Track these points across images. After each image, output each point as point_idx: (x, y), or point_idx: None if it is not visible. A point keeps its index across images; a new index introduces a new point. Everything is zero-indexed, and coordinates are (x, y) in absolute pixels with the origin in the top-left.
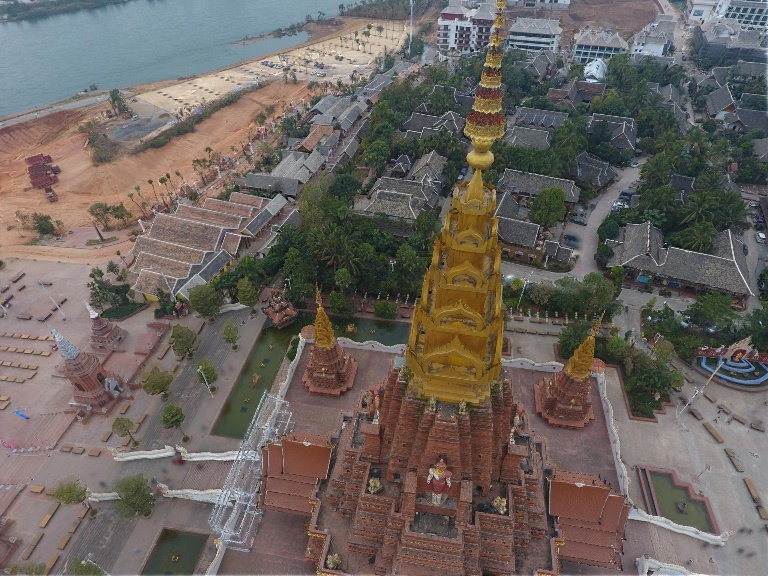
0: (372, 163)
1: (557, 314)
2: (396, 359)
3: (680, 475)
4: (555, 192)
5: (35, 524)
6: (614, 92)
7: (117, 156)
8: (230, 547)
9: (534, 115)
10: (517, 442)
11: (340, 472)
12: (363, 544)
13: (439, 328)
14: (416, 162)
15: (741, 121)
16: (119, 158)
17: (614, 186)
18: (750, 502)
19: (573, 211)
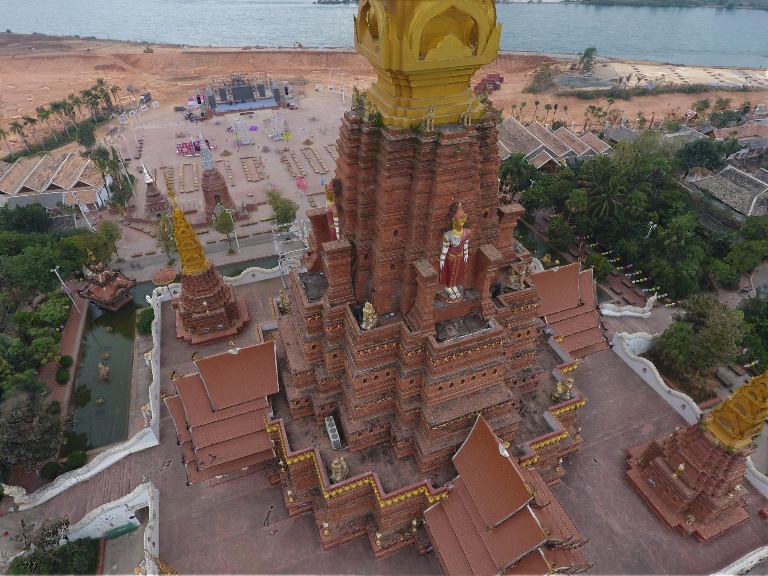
0: None
1: None
2: None
3: None
4: None
5: (261, 217)
6: None
7: (544, 92)
8: (282, 277)
9: None
10: (473, 319)
11: None
12: None
13: None
14: None
15: None
16: (544, 94)
17: None
18: None
19: None
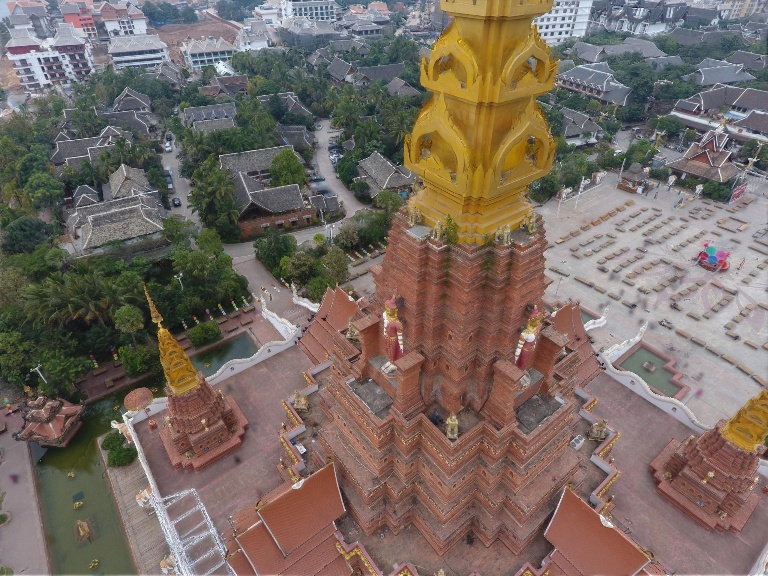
0: (45, 203)
1: (372, 246)
2: (411, 232)
3: (547, 300)
4: (288, 153)
5: None
6: (260, 77)
7: None
8: None
9: (201, 113)
10: None
11: (368, 478)
12: (459, 526)
13: (510, 94)
14: (104, 188)
15: (366, 76)
16: None
17: (318, 146)
18: (589, 289)
19: (305, 173)
